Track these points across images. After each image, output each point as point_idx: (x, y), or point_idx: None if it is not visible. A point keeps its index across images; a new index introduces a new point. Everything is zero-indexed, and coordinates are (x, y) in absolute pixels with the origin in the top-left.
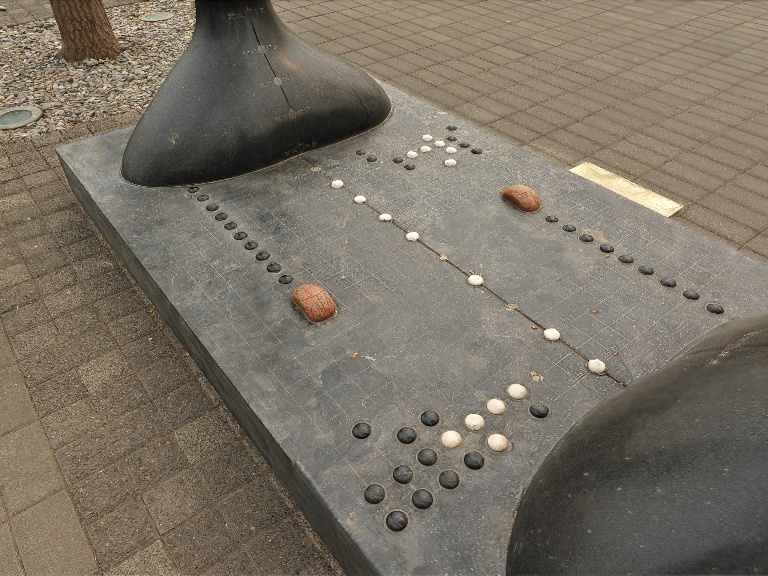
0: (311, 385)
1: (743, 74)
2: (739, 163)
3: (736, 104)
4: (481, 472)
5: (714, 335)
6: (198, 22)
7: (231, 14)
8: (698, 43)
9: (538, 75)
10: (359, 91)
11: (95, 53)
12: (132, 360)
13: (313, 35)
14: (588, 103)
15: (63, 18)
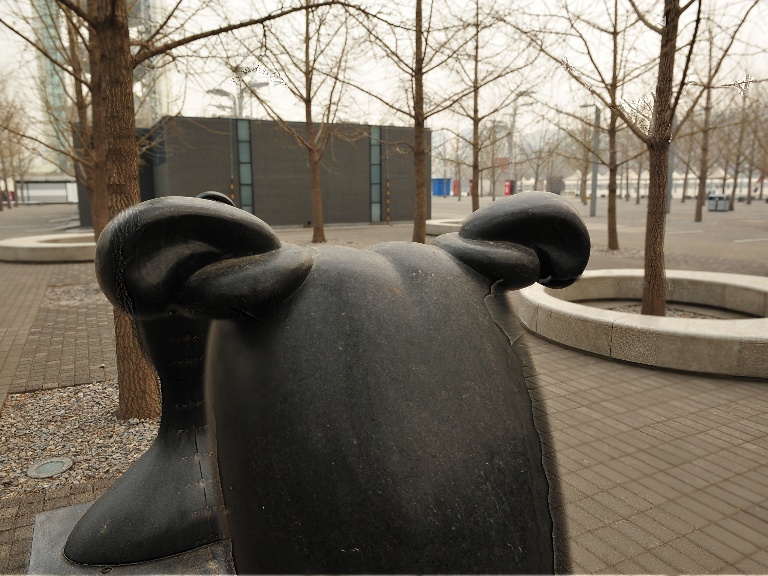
0: None
1: (683, 488)
2: None
3: (661, 523)
4: None
5: None
6: None
7: (180, 430)
8: (654, 449)
9: None
10: None
11: (140, 414)
12: None
13: None
14: None
15: (123, 388)
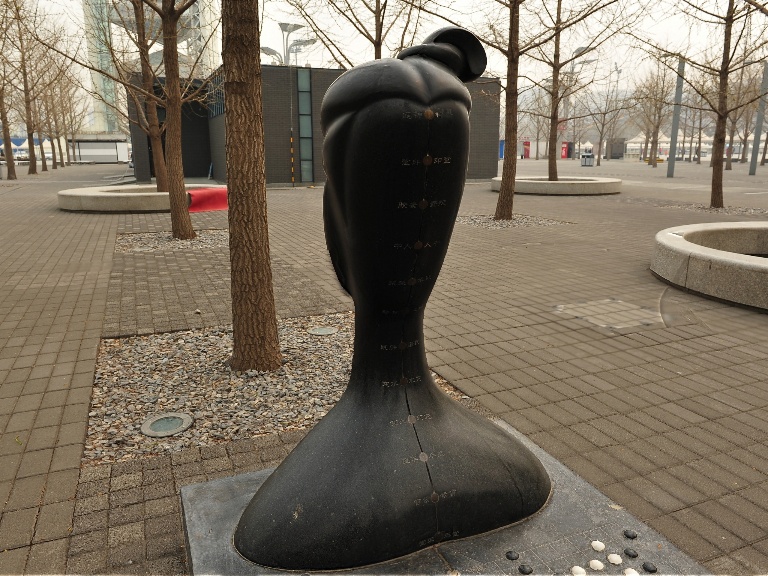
0: None
1: None
2: None
3: None
4: None
5: None
6: (351, 383)
7: (385, 381)
8: None
9: (727, 449)
10: (515, 471)
11: (258, 365)
12: None
13: (466, 367)
14: None
15: (239, 334)
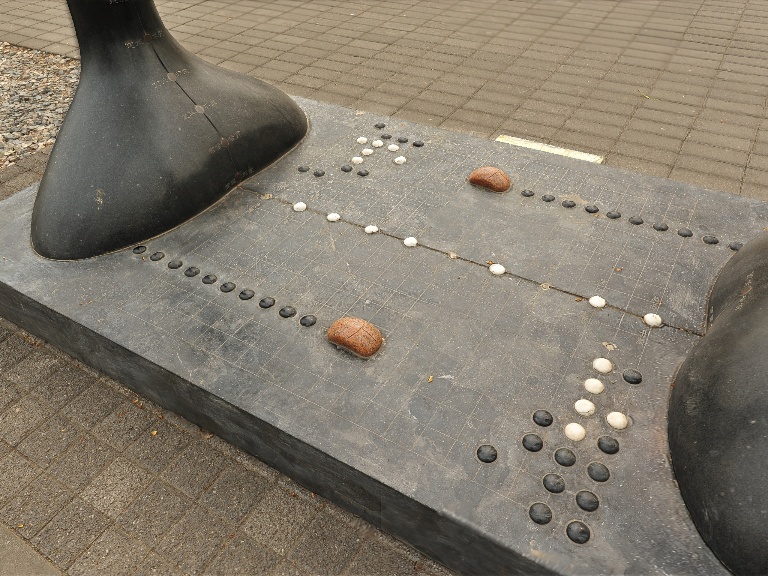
0: (406, 424)
1: (583, 31)
2: (624, 110)
3: (592, 59)
4: (621, 454)
5: (765, 262)
6: (87, 58)
7: (129, 42)
8: (531, 10)
9: (410, 61)
10: (278, 105)
11: None
12: (146, 463)
13: None
14: (470, 80)
15: None
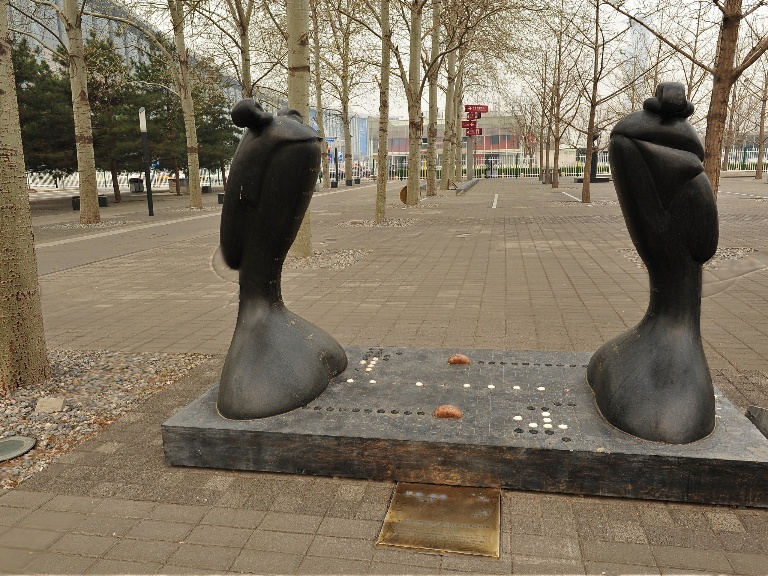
0: None
1: None
2: None
3: None
4: None
5: (315, 355)
6: None
7: None
8: None
9: None
10: (621, 392)
11: None
12: None
13: None
14: None
15: None
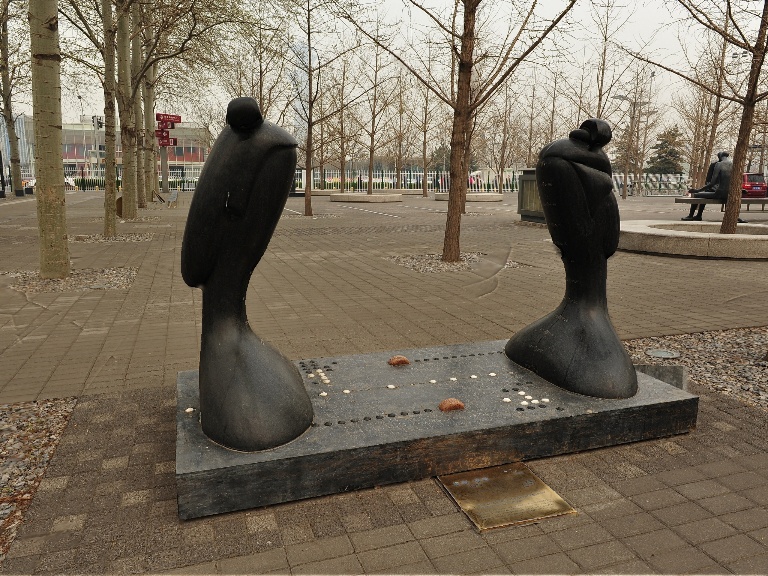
0: None
1: None
2: None
3: None
4: None
5: None
6: None
7: None
8: None
9: None
10: (575, 365)
11: None
12: None
13: None
14: (757, 570)
15: None
